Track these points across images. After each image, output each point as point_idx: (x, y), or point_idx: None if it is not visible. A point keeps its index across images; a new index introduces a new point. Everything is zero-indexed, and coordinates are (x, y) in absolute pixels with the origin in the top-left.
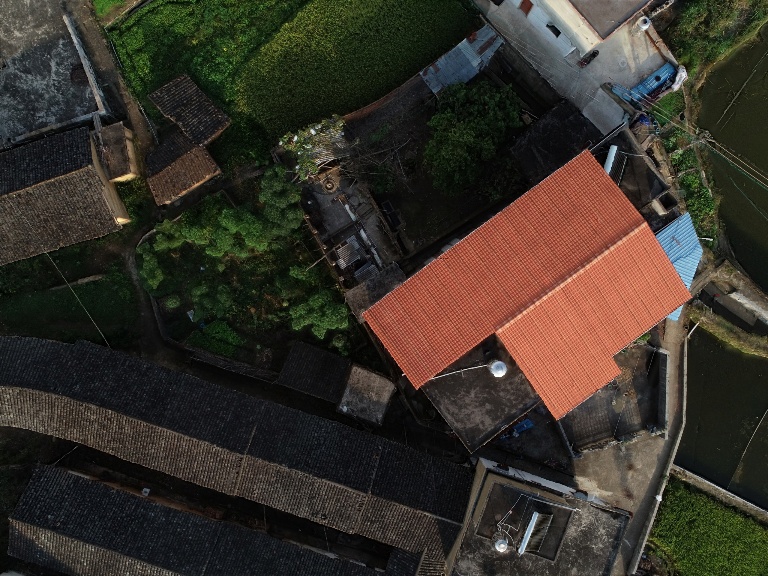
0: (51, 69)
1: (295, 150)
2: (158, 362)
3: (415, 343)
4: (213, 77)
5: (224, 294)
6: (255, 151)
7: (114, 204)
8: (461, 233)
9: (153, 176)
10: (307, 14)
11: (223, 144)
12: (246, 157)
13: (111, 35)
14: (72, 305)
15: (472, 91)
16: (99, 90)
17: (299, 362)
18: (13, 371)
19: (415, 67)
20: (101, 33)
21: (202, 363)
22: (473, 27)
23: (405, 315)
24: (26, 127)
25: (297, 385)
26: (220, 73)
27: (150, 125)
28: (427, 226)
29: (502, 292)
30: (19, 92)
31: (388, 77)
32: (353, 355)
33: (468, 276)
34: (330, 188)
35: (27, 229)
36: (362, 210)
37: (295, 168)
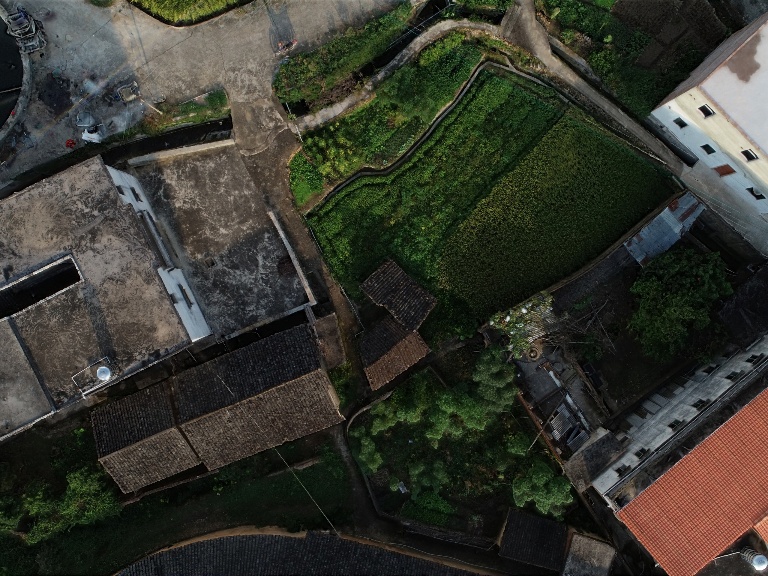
0: (258, 263)
1: (507, 329)
2: (371, 534)
3: (674, 541)
4: (415, 257)
5: (441, 471)
6: (462, 328)
7: (333, 395)
8: (660, 387)
9: (370, 365)
10: (502, 188)
11: (427, 321)
12: (452, 333)
13: (310, 222)
14: (290, 490)
15: (682, 263)
16: (306, 280)
17: (517, 531)
18: (254, 572)
19: (612, 233)
20: (303, 222)
21: (416, 534)
22: (666, 189)
23: (661, 513)
24: (237, 322)
25: (519, 556)
26: (420, 252)
27: (352, 306)
28: (629, 385)
29: (757, 485)
30: (228, 288)
31: (586, 244)
32: (566, 518)
33: (721, 471)
34: (534, 356)
35: (255, 430)
36: (566, 375)
37: (507, 346)
